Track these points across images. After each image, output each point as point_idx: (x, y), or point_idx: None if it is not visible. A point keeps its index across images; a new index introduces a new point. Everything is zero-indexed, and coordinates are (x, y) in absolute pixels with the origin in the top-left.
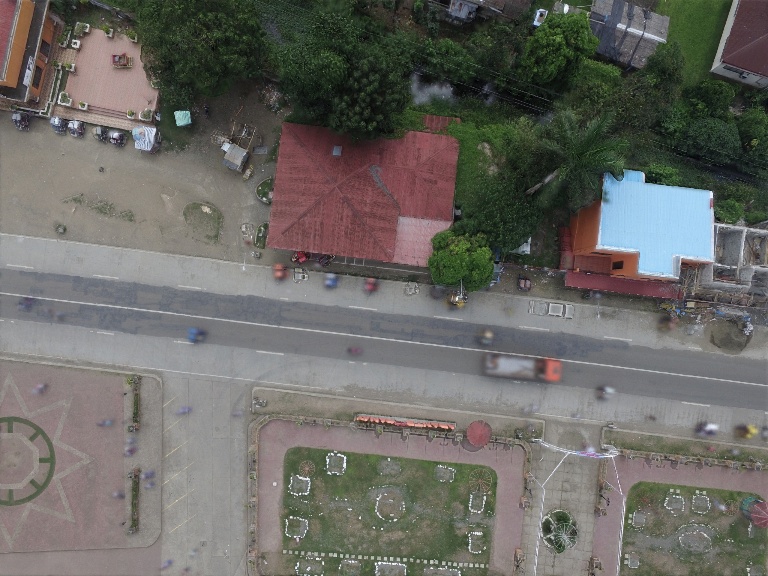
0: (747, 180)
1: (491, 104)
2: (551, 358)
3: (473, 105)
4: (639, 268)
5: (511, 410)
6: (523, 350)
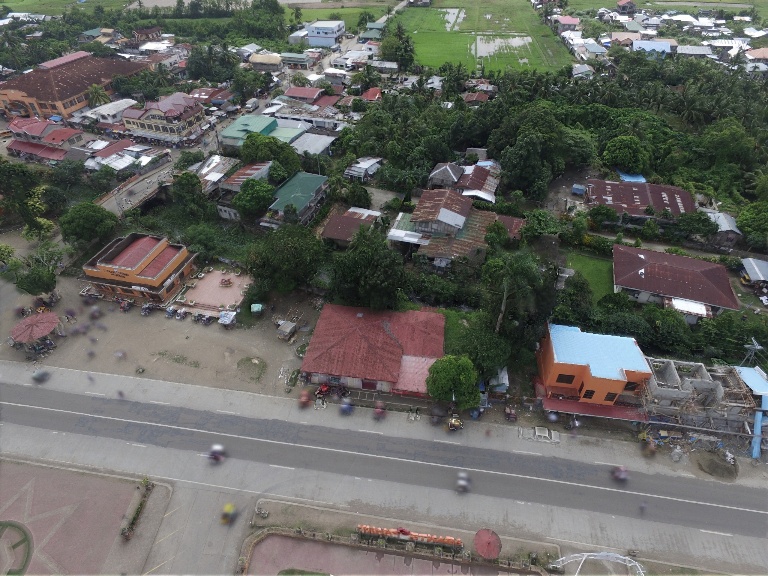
0: (673, 357)
1: (467, 310)
2: (550, 480)
3: None
4: None
5: (520, 533)
6: (521, 472)
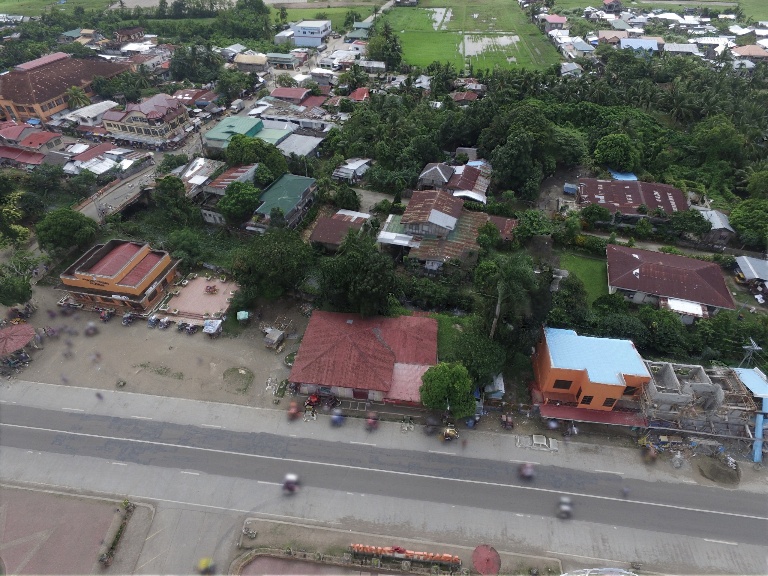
0: (670, 358)
1: (460, 314)
2: (549, 490)
3: (447, 314)
4: (591, 380)
5: (520, 547)
6: (519, 482)
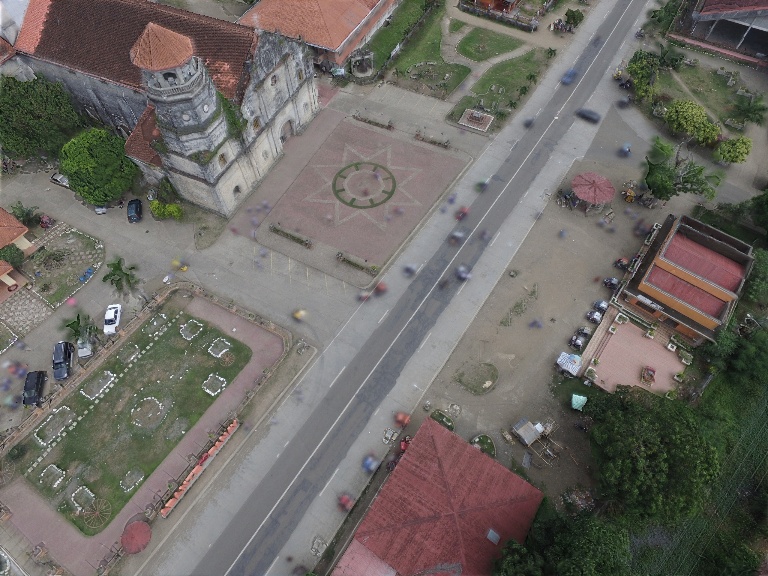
0: None
1: None
2: None
3: None
4: None
5: None
6: None
